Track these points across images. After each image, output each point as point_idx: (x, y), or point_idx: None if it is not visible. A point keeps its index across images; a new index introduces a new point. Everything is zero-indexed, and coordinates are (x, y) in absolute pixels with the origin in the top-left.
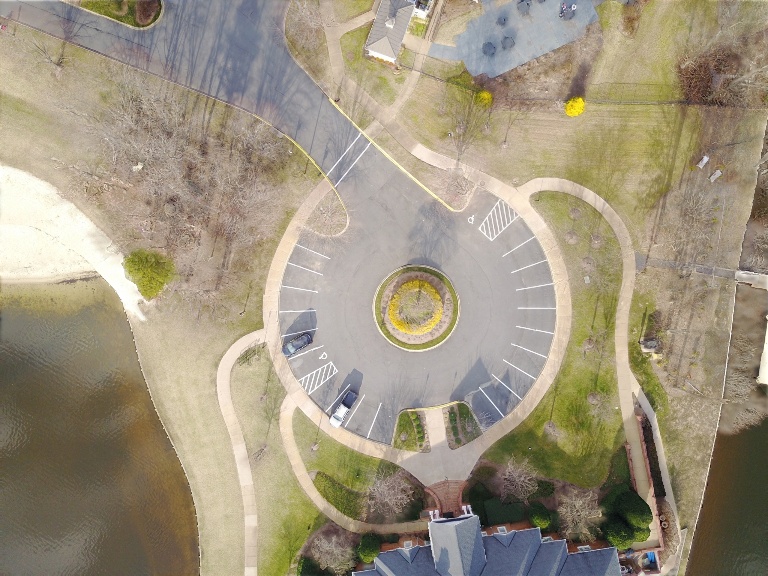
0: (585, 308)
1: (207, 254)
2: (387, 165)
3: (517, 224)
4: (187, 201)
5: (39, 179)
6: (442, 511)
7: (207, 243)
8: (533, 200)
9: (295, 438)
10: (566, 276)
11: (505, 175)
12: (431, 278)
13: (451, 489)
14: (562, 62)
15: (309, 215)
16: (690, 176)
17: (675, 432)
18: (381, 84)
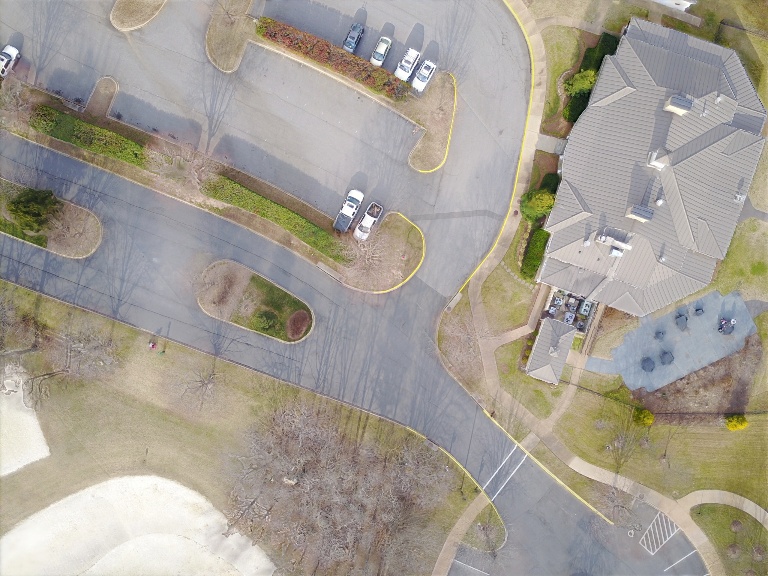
0: None
1: (362, 567)
2: (544, 477)
3: (678, 537)
4: (340, 512)
5: (187, 488)
6: None
7: (361, 554)
8: (694, 513)
9: None
10: None
11: (665, 488)
12: None
13: None
14: (722, 376)
15: (466, 530)
16: None
17: None
18: (537, 397)
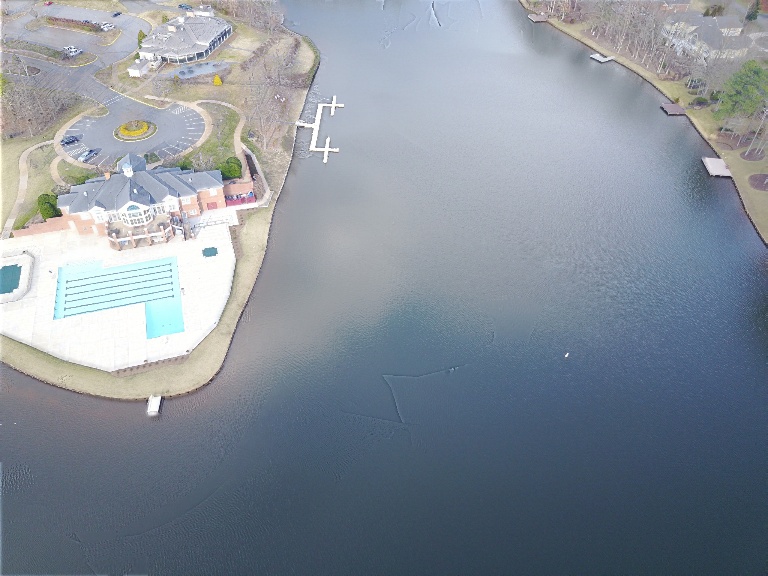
0: None
1: None
2: None
3: (190, 110)
4: None
5: None
6: None
7: None
8: (198, 104)
9: (57, 168)
10: (211, 120)
11: (186, 100)
12: None
13: None
14: None
15: None
16: None
17: (266, 162)
18: (134, 83)
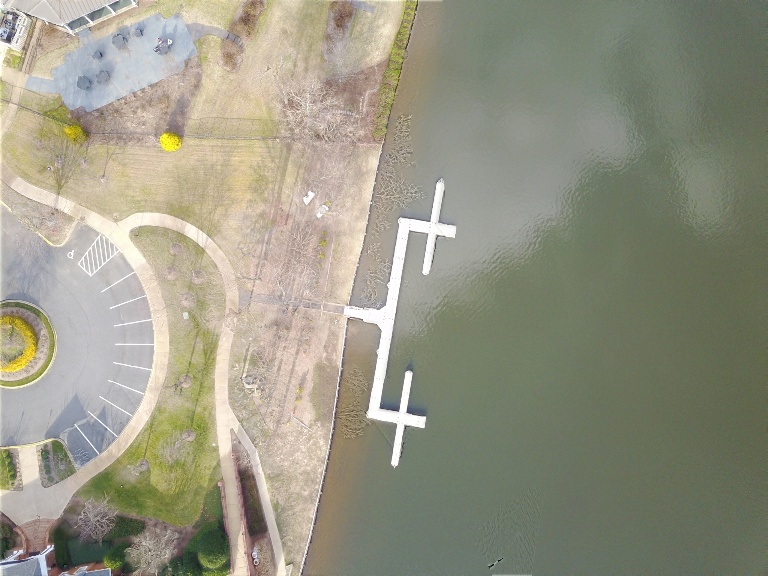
0: (183, 344)
1: None
2: None
3: (117, 259)
4: None
5: None
6: (28, 551)
7: None
8: (133, 235)
9: None
10: (164, 312)
11: (105, 210)
12: (27, 314)
13: (41, 528)
14: (160, 97)
15: None
16: (297, 211)
17: (280, 468)
18: None
